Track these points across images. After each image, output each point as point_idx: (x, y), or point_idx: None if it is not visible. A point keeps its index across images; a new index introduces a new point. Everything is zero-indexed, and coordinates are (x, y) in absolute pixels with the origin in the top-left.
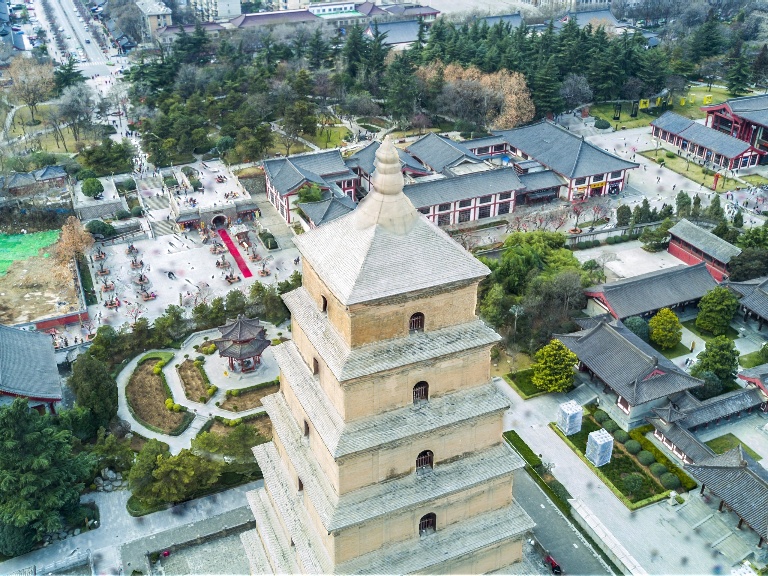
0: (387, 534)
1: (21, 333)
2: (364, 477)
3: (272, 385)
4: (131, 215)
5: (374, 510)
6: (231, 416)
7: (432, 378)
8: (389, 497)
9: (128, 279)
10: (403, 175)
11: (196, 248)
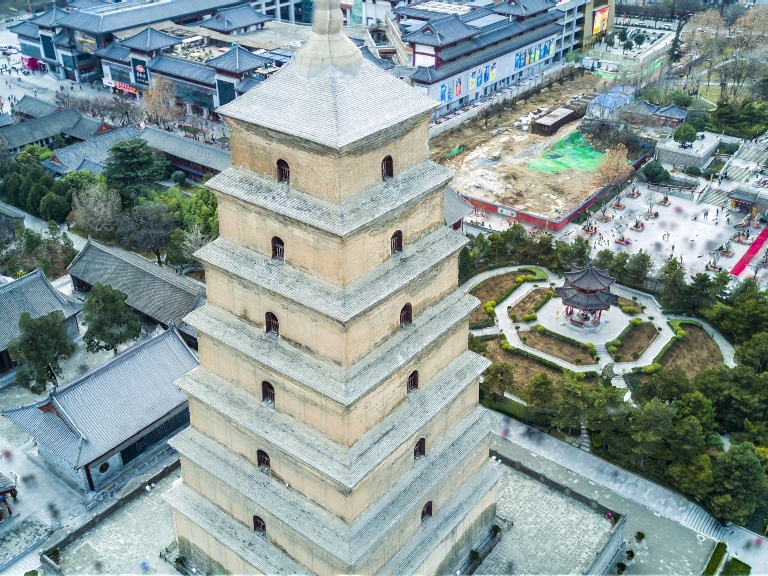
0: (236, 371)
1: (454, 194)
2: (224, 299)
3: (578, 346)
4: (702, 174)
5: (216, 331)
6: (516, 343)
7: (287, 240)
8: (233, 332)
9: (629, 220)
10: (330, 15)
11: (722, 227)
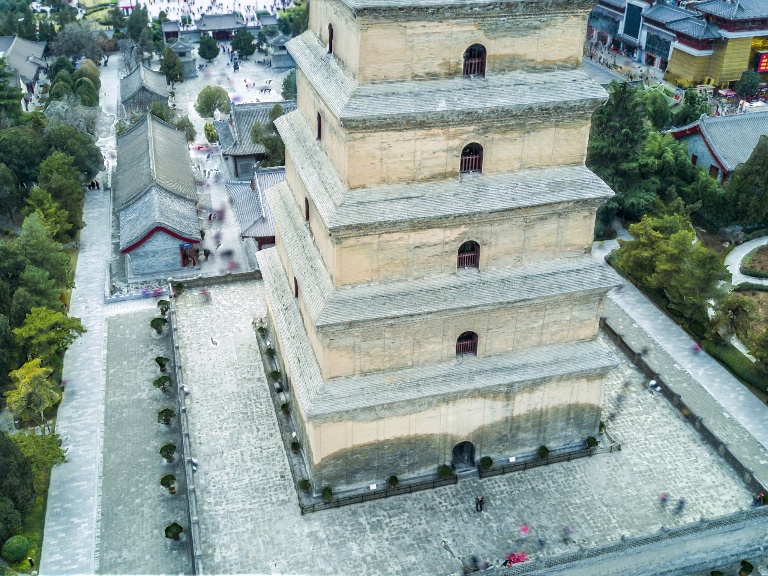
0: None
1: None
2: None
3: None
4: None
5: None
6: None
7: None
8: None
9: None
10: None
11: None
